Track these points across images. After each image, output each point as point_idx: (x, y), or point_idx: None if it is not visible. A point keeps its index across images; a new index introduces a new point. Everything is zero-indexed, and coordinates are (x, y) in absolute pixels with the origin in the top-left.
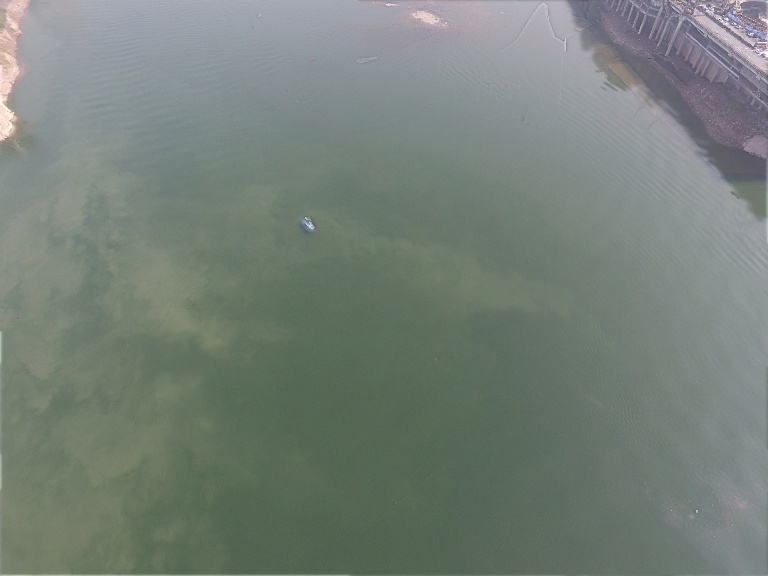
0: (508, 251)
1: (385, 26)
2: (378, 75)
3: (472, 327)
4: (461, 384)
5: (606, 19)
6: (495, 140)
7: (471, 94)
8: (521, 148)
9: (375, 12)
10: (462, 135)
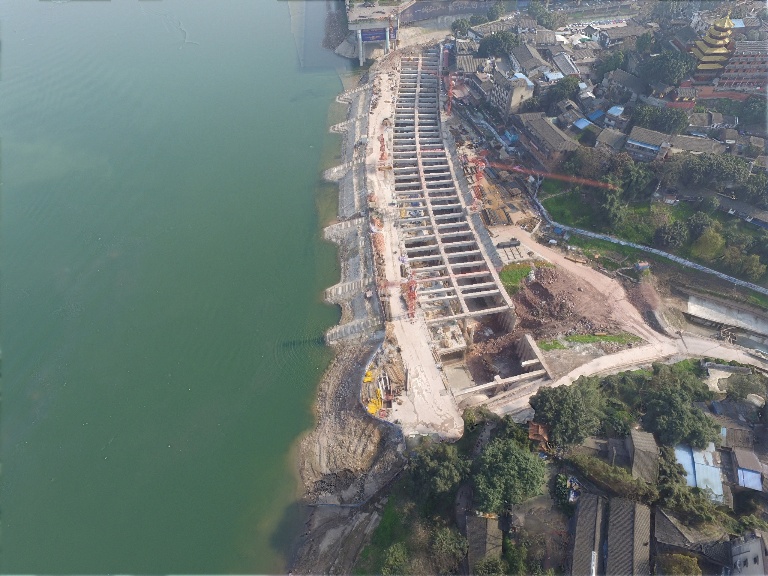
0: (100, 121)
1: None
2: (107, 19)
3: (40, 165)
4: (8, 195)
5: None
6: (156, 56)
7: (163, 26)
8: (165, 59)
9: None
10: (134, 55)
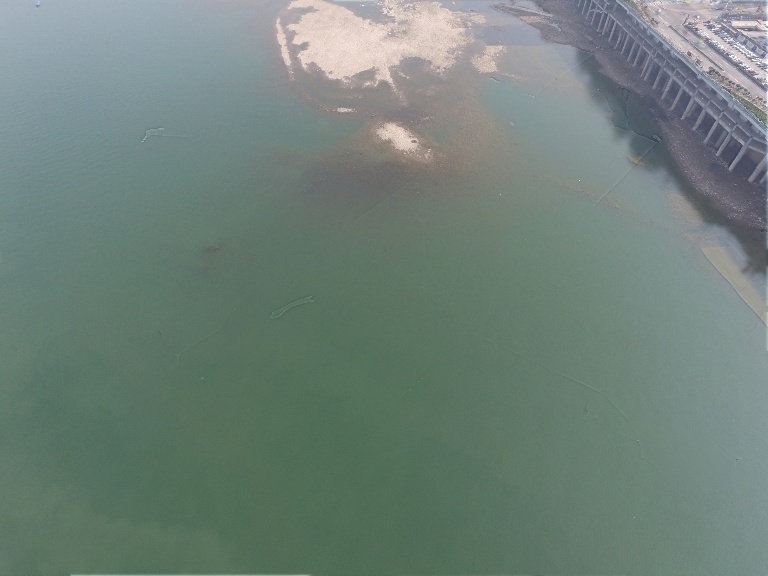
0: None
1: (335, 160)
2: (324, 268)
3: None
4: None
5: (671, 137)
6: (543, 488)
7: None
8: (603, 537)
9: (321, 127)
10: (478, 470)
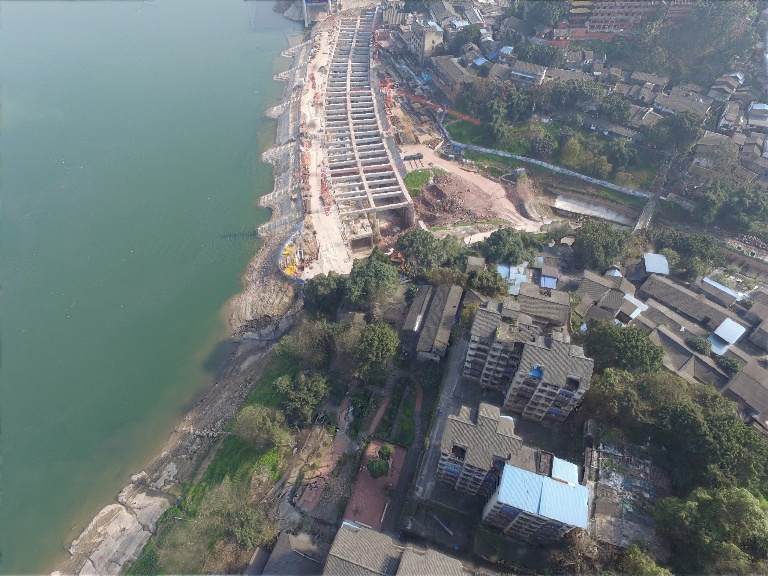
0: (64, 72)
1: None
2: None
3: (8, 108)
4: None
5: None
6: (117, 19)
7: None
8: None
9: None
10: (96, 18)
